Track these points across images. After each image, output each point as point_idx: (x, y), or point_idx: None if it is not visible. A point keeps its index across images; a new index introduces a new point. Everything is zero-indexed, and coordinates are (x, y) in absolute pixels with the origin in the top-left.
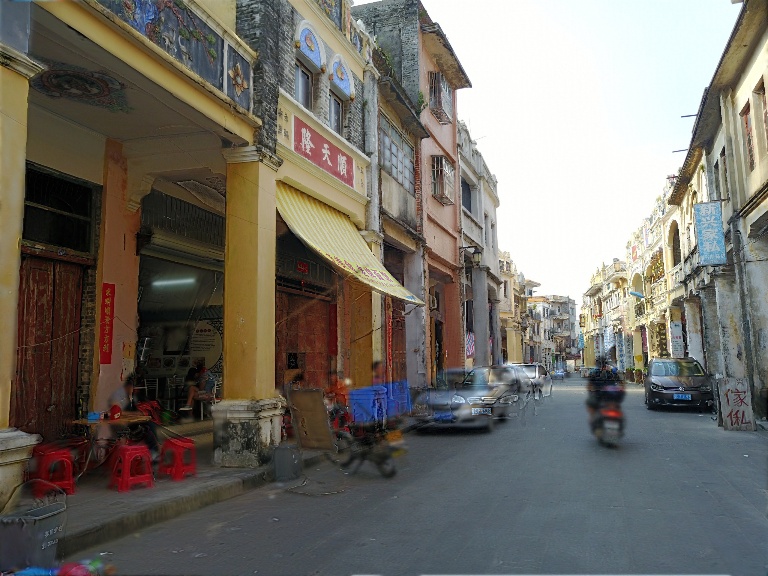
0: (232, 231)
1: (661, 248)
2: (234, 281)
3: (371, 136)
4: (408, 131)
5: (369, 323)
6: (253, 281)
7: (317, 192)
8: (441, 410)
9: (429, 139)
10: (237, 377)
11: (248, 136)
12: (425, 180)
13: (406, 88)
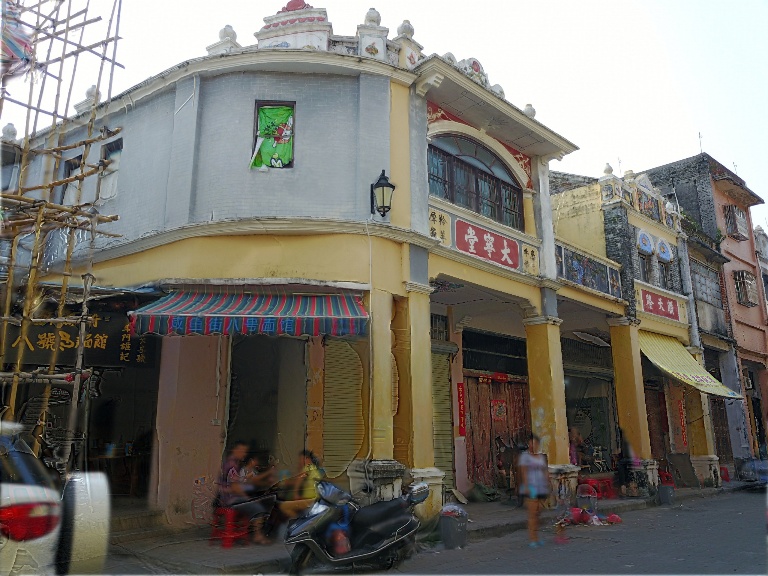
0: (617, 364)
1: None
2: (622, 392)
3: (687, 281)
4: (712, 261)
5: (700, 410)
6: (634, 392)
7: (658, 330)
8: (767, 478)
9: (729, 258)
10: (630, 446)
11: (622, 312)
12: (730, 293)
13: (705, 226)
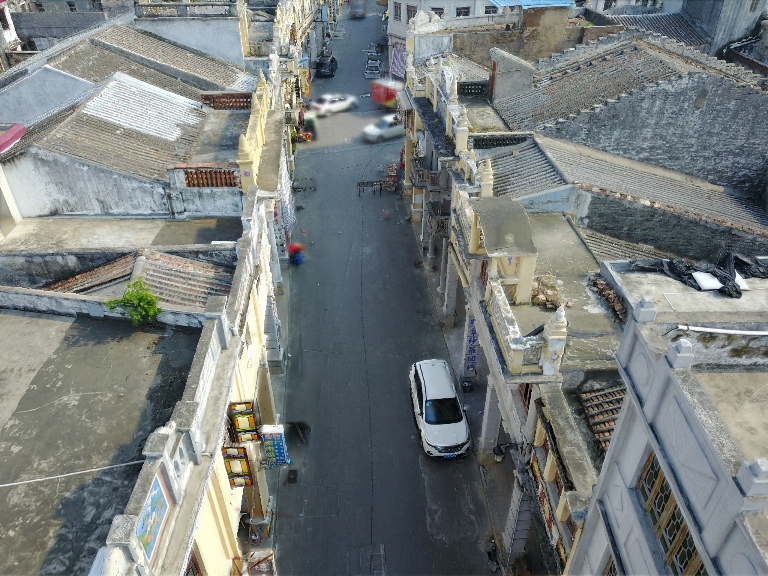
0: None
1: (294, 23)
2: None
3: None
4: None
5: None
6: None
7: None
8: None
9: None
10: None
11: None
12: None
13: None
